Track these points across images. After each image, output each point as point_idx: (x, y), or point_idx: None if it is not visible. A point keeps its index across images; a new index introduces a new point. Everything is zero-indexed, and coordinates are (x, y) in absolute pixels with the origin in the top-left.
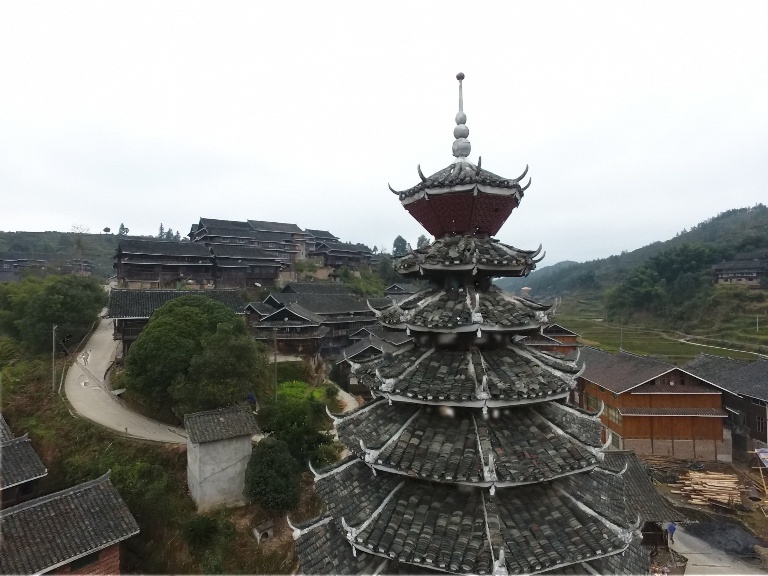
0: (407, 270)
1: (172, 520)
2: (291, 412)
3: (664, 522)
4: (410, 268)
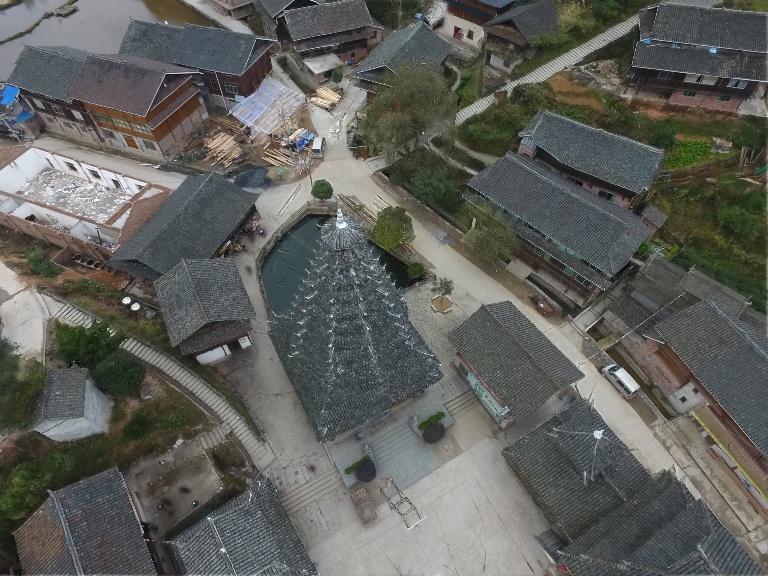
0: None
1: (109, 449)
2: (81, 340)
3: None
4: None
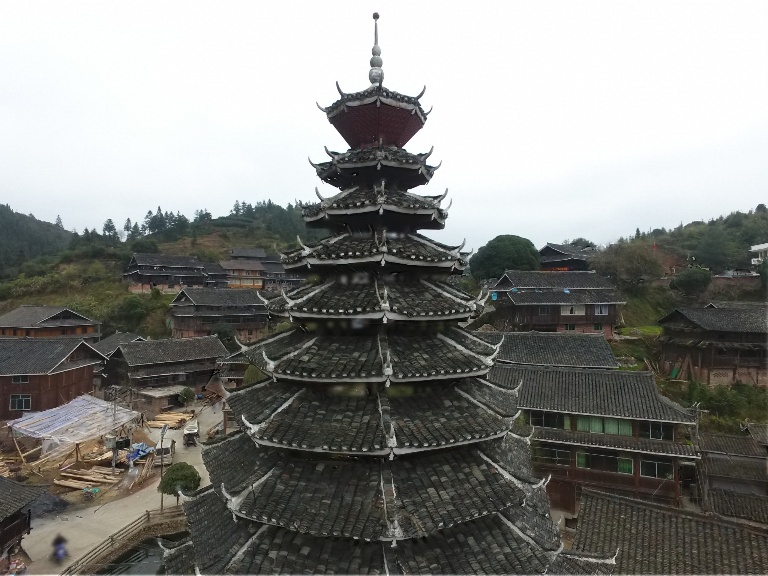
0: (400, 165)
1: None
2: None
3: (34, 500)
4: (409, 164)
